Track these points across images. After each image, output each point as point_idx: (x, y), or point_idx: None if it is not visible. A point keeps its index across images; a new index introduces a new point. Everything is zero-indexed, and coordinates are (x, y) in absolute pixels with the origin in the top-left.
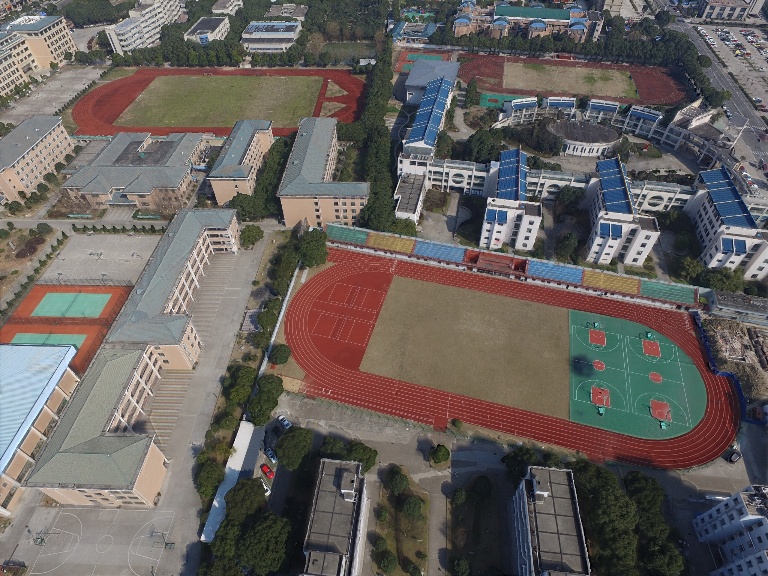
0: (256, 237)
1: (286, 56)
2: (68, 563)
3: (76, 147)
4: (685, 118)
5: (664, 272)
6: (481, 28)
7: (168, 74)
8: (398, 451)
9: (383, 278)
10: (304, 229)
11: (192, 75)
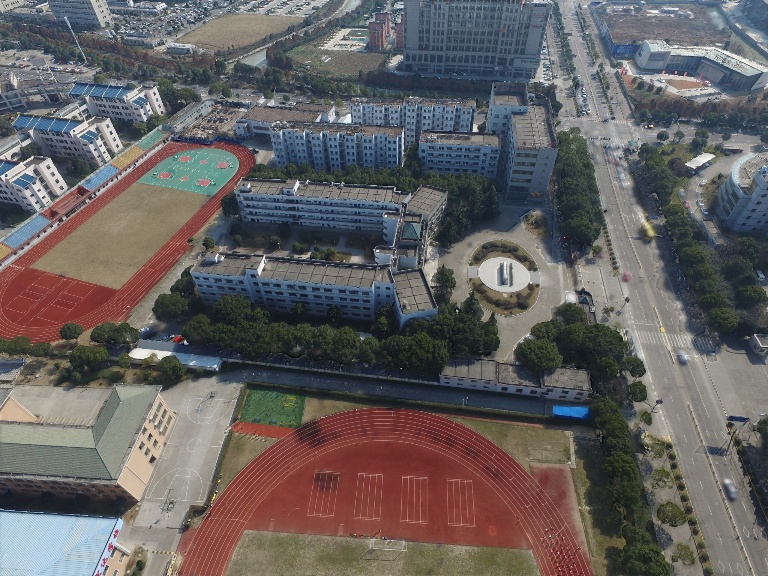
0: None
1: None
2: (200, 470)
3: None
4: (2, 87)
5: (135, 141)
6: None
7: None
8: None
9: (26, 274)
10: None
11: None
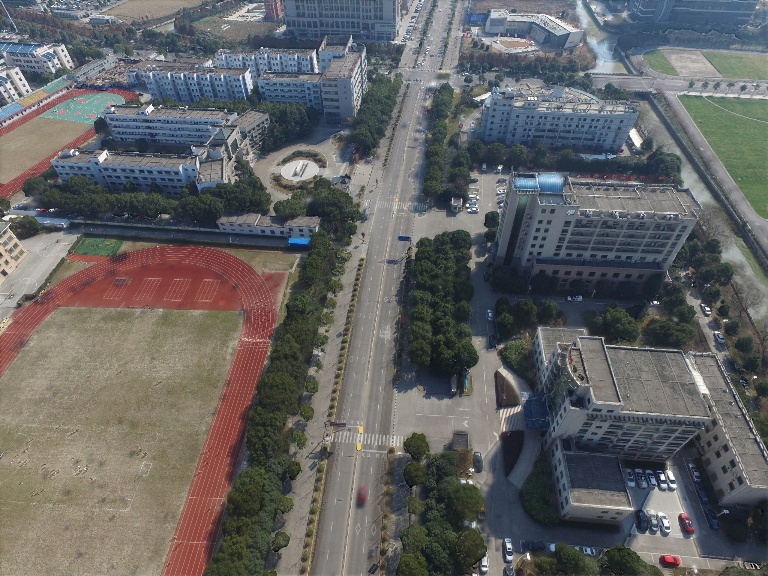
0: None
1: None
2: (37, 279)
3: None
4: None
5: None
6: None
7: None
8: None
9: None
10: None
11: None
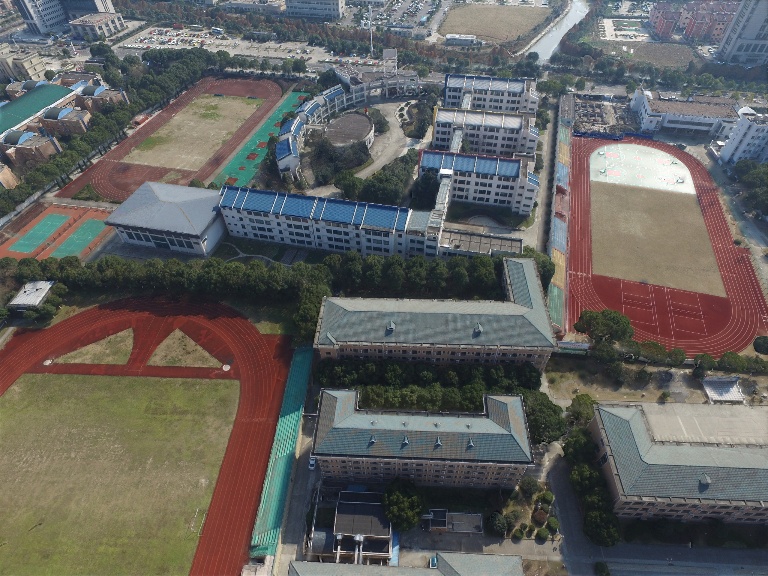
0: None
1: None
2: None
3: None
4: None
5: None
6: None
7: None
8: None
9: (601, 282)
10: None
11: None
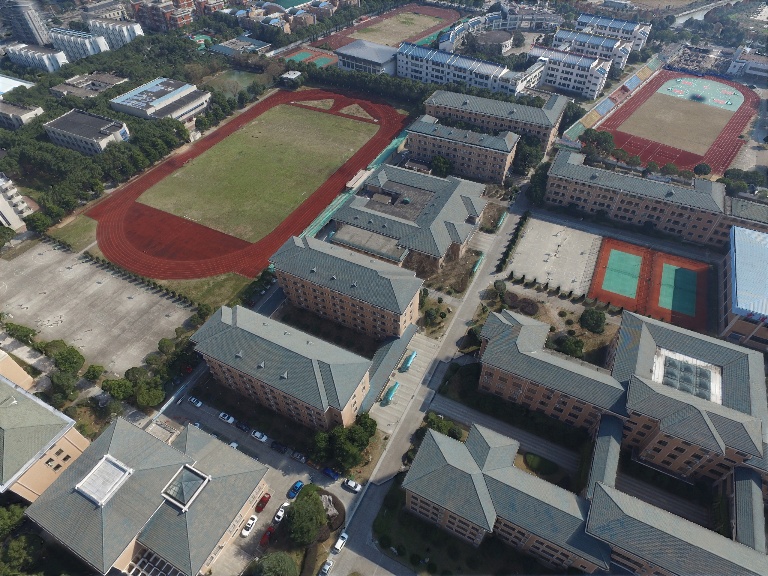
0: None
1: (227, 104)
2: None
3: None
4: None
5: (630, 64)
6: None
7: (139, 191)
8: (762, 156)
9: (618, 134)
10: (563, 145)
11: (169, 174)
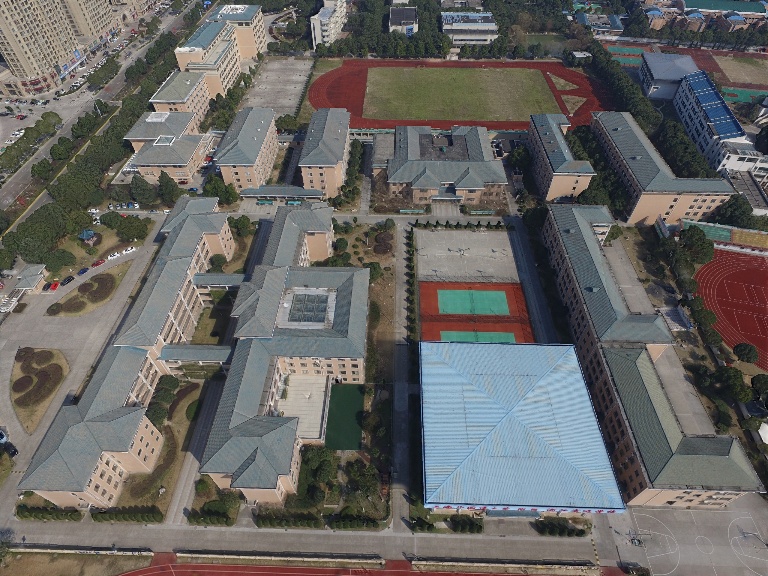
0: (618, 234)
1: (497, 48)
2: (683, 564)
3: (356, 140)
4: None
5: None
6: (667, 20)
7: (378, 66)
8: None
9: (767, 276)
10: (659, 226)
11: (403, 67)
